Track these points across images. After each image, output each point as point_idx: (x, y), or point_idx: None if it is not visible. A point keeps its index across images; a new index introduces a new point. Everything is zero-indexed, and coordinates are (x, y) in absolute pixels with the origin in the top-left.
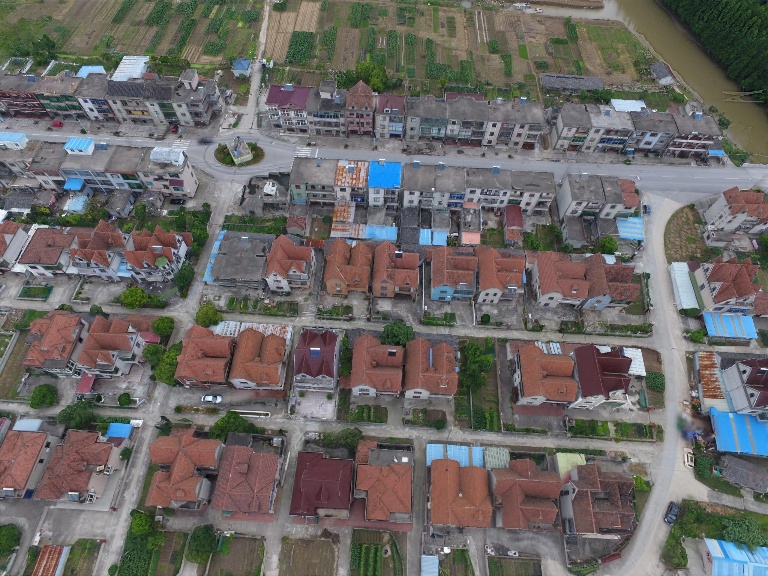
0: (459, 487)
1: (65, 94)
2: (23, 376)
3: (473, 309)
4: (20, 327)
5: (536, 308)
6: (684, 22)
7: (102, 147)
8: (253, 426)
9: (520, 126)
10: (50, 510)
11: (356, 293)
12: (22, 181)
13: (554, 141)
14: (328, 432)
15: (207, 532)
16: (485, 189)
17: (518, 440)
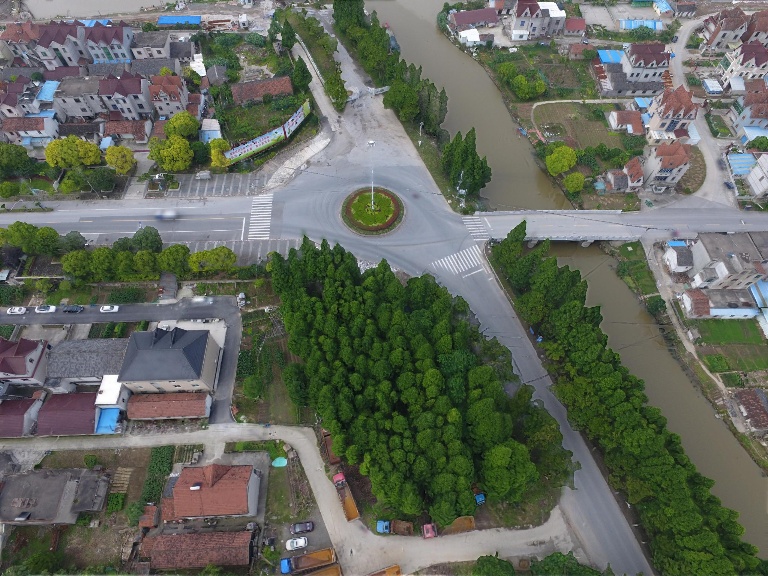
0: None
1: None
2: None
3: None
4: None
5: None
6: None
7: None
8: None
9: None
10: None
11: None
12: None
13: None
14: None
15: None
16: None
17: None
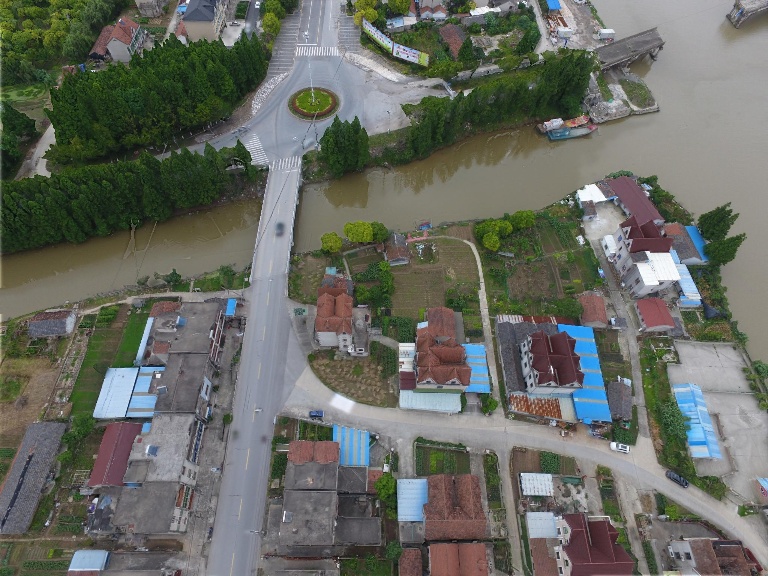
0: None
1: None
2: None
3: None
4: None
5: None
6: None
7: None
8: None
9: None
10: None
11: None
12: None
13: None
14: None
15: None
16: None
17: None
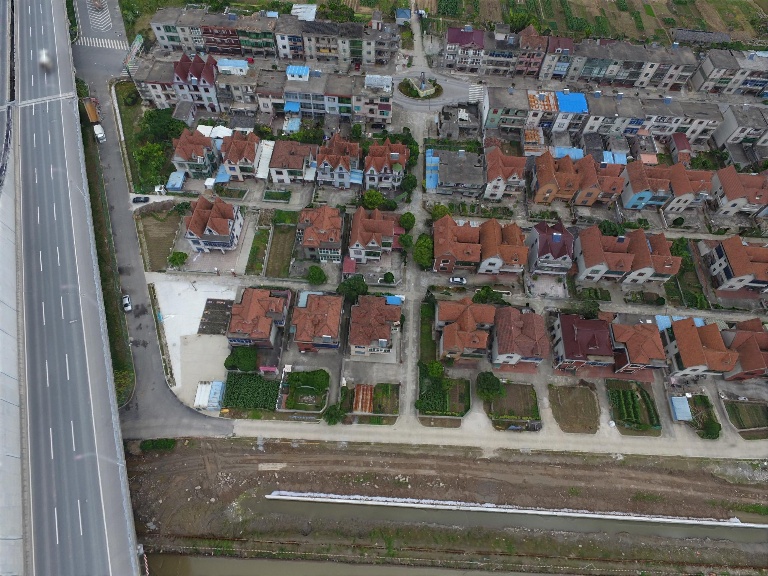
0: (701, 341)
1: (266, 31)
2: (291, 260)
3: (663, 216)
4: (277, 221)
5: (715, 217)
6: None
7: (316, 74)
8: (503, 300)
9: (675, 67)
10: (346, 362)
11: (557, 202)
12: (239, 105)
13: (699, 83)
14: (564, 308)
15: (492, 376)
16: (661, 116)
17: (725, 316)
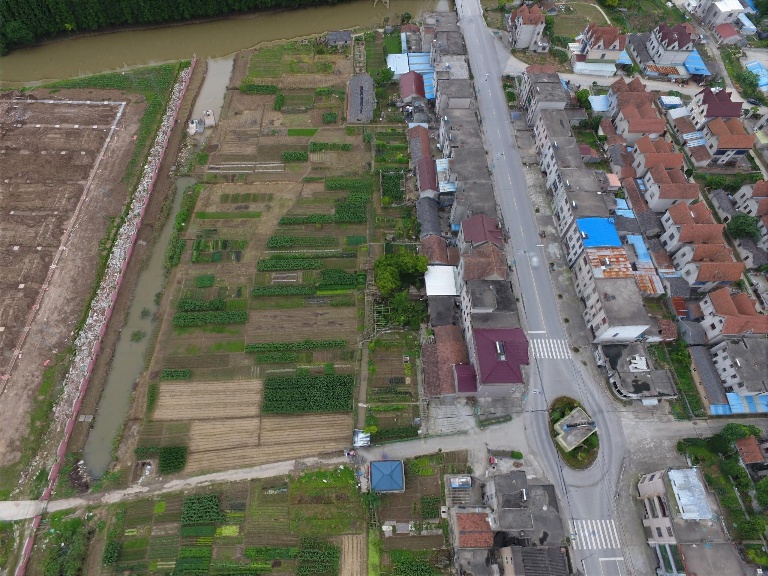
0: None
1: None
2: None
3: None
4: None
5: None
6: (248, 10)
7: None
8: None
9: None
10: None
11: None
12: None
13: None
14: None
15: None
16: None
17: (759, 165)
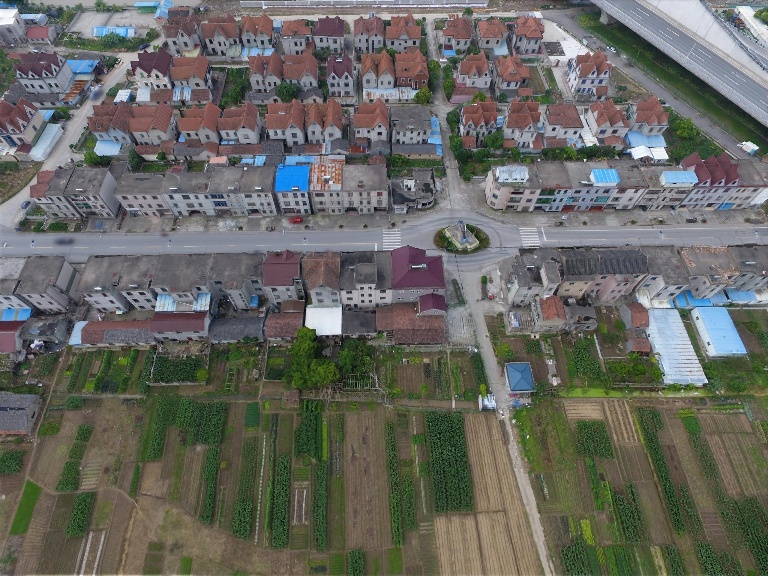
0: None
1: (687, 247)
2: None
3: None
4: None
5: None
6: None
7: None
8: None
9: None
10: None
11: None
12: None
13: None
14: None
15: (385, 25)
16: None
17: None
